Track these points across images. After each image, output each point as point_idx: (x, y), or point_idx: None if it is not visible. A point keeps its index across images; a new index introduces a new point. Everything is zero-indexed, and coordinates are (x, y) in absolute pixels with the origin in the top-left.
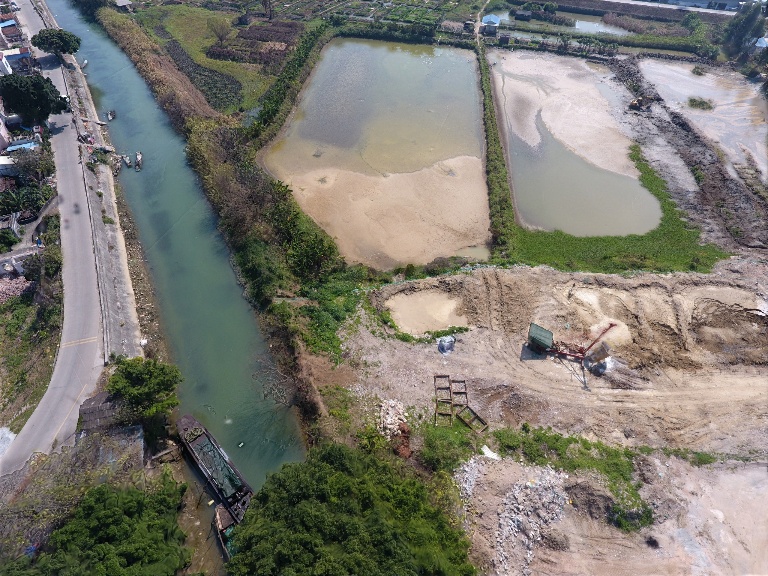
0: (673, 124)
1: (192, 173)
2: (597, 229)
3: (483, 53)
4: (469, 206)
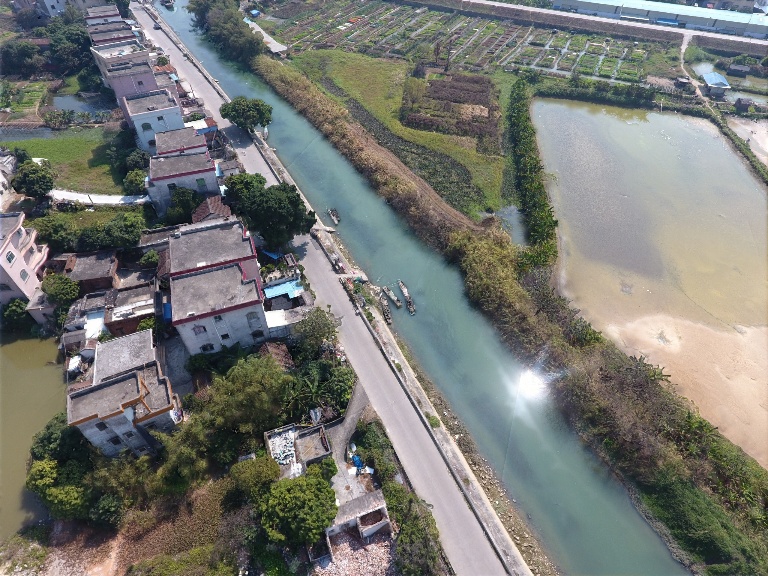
0: None
1: (485, 321)
2: None
3: (726, 125)
4: None
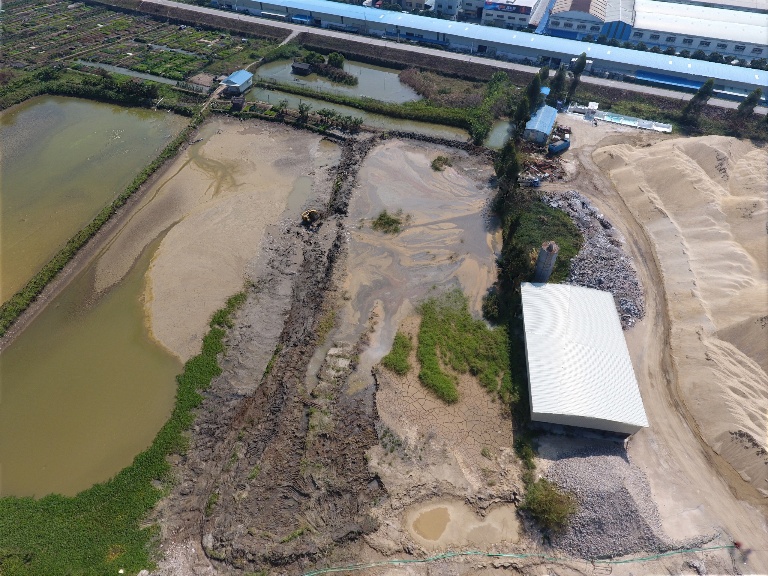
0: (325, 257)
1: None
2: (16, 477)
3: (195, 124)
4: None
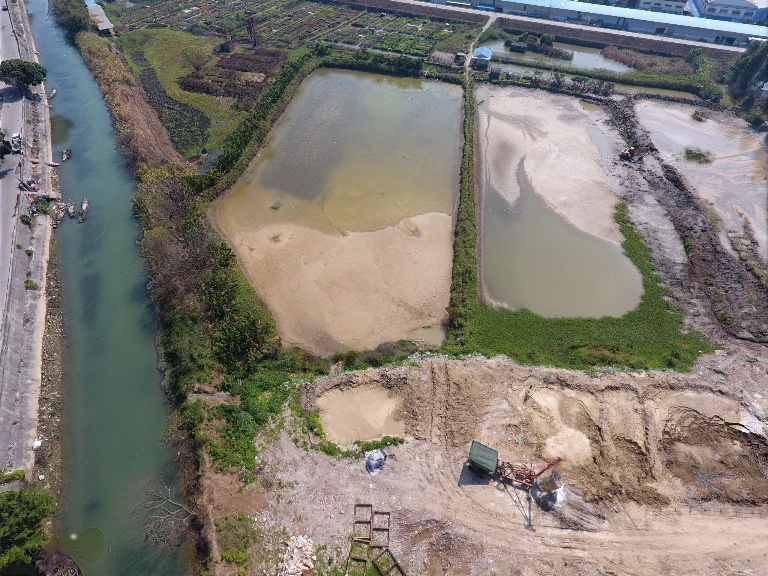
0: (665, 179)
1: (137, 226)
2: (569, 308)
3: (471, 89)
4: (430, 275)
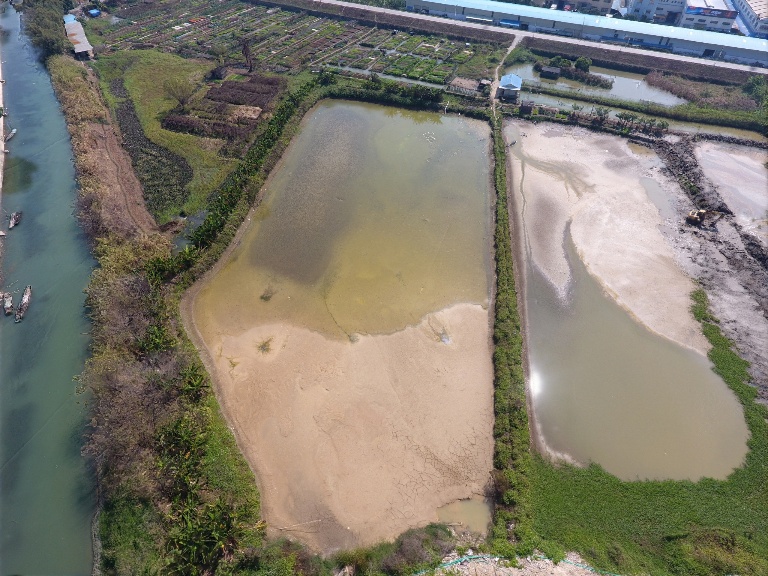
0: (749, 255)
1: (89, 328)
2: (653, 461)
3: (499, 127)
4: (465, 408)
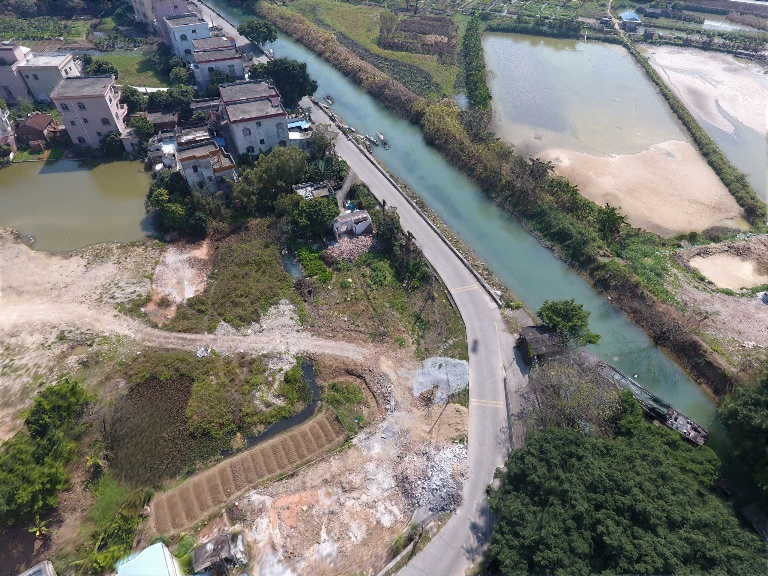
0: None
1: (437, 152)
2: None
3: (634, 48)
4: (706, 184)
